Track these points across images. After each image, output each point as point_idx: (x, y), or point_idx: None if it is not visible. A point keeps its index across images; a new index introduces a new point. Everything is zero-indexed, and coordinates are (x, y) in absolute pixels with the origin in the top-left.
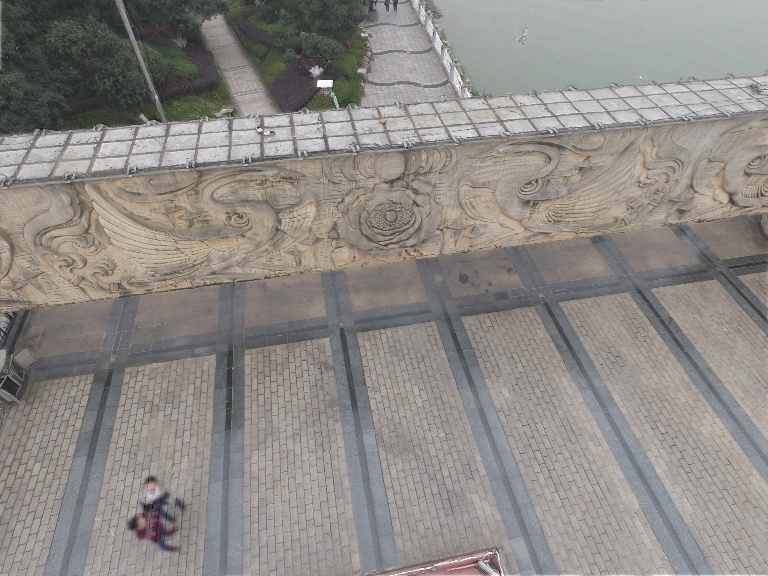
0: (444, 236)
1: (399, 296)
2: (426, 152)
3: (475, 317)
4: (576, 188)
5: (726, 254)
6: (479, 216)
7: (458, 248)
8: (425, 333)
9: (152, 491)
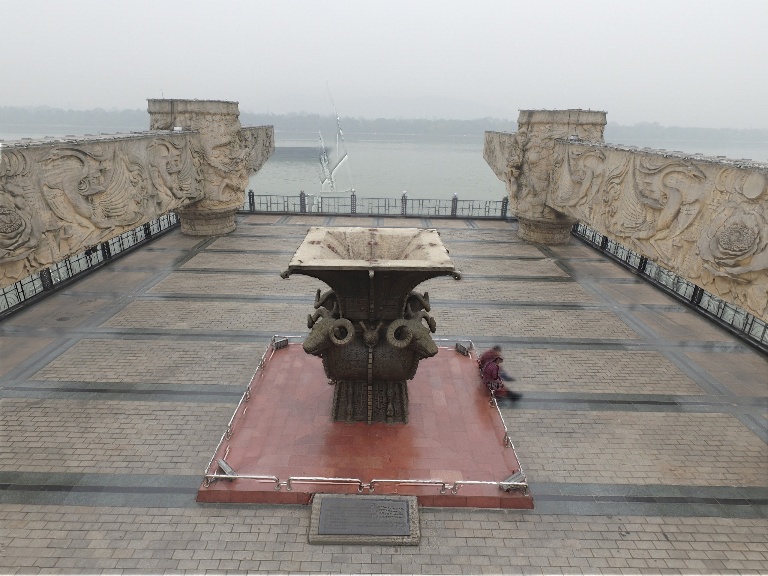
0: (48, 241)
1: (26, 351)
2: (6, 155)
3: (107, 322)
4: (106, 185)
5: (189, 246)
6: (63, 217)
7: (62, 253)
8: (86, 345)
9: (0, 569)
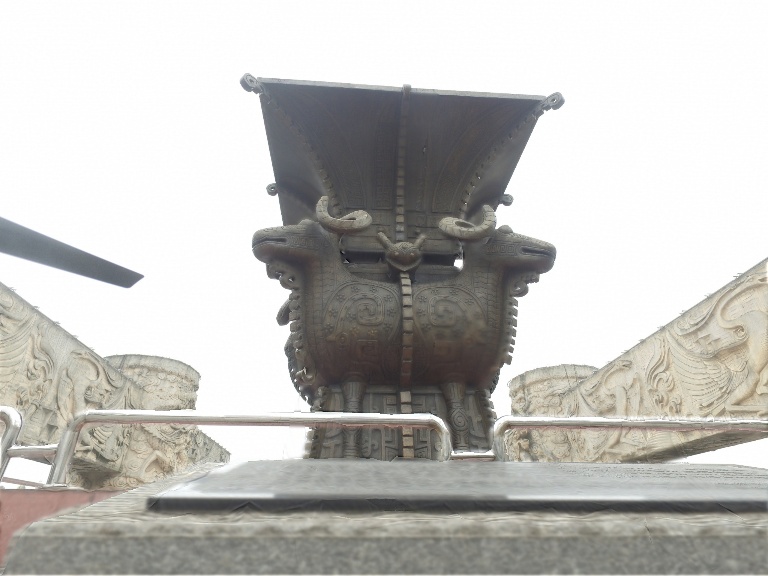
0: None
1: None
2: None
3: None
4: None
5: None
6: None
7: None
8: None
9: None
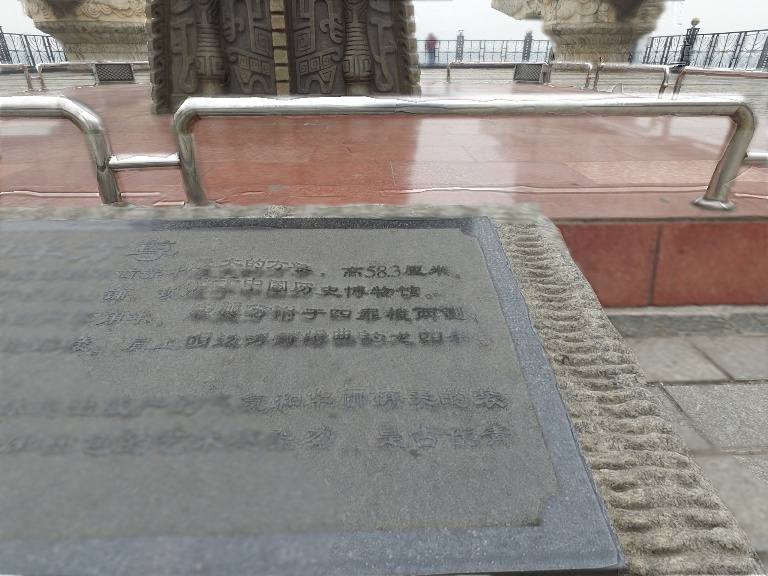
0: None
1: None
2: None
3: None
4: None
5: None
6: None
7: None
8: None
9: None
